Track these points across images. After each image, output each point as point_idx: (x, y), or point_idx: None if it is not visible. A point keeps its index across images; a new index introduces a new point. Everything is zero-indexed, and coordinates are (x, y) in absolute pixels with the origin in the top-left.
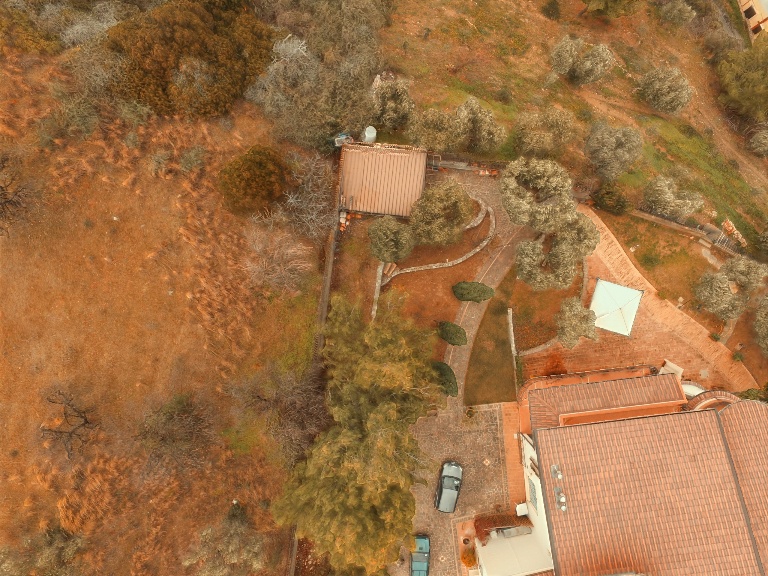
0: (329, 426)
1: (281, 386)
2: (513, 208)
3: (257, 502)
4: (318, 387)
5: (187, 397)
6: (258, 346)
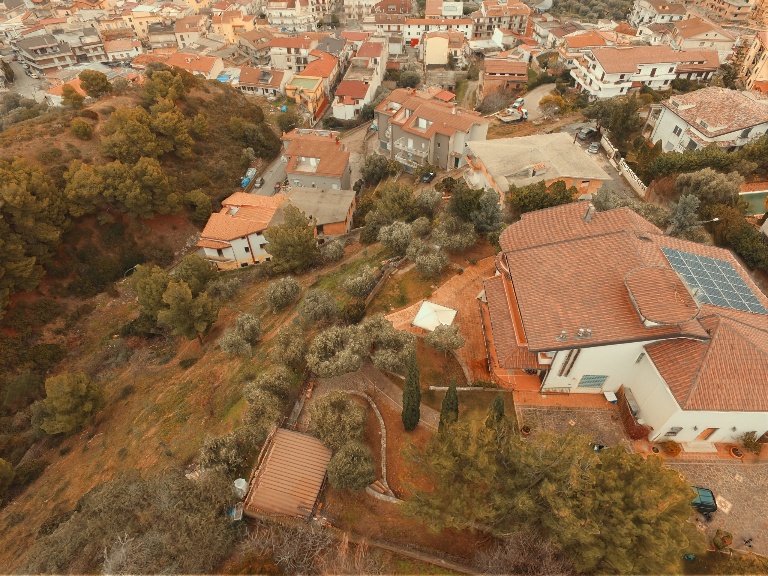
0: (542, 528)
1: (498, 575)
2: (345, 364)
3: None
4: None
5: None
6: None
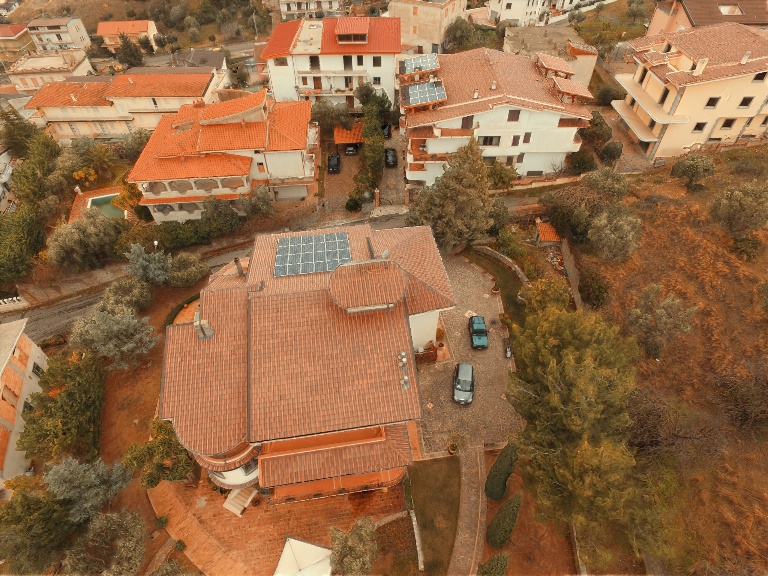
0: None
1: None
2: None
3: (640, 360)
4: (640, 452)
5: (759, 440)
6: (707, 501)
